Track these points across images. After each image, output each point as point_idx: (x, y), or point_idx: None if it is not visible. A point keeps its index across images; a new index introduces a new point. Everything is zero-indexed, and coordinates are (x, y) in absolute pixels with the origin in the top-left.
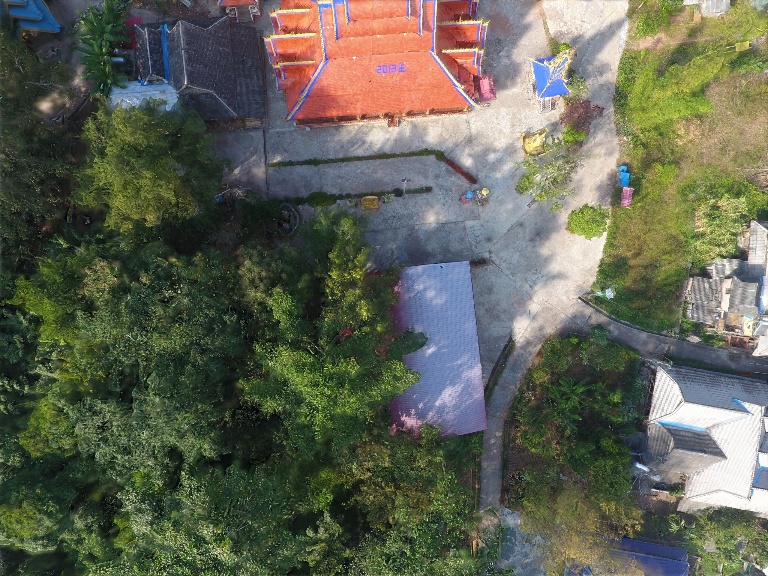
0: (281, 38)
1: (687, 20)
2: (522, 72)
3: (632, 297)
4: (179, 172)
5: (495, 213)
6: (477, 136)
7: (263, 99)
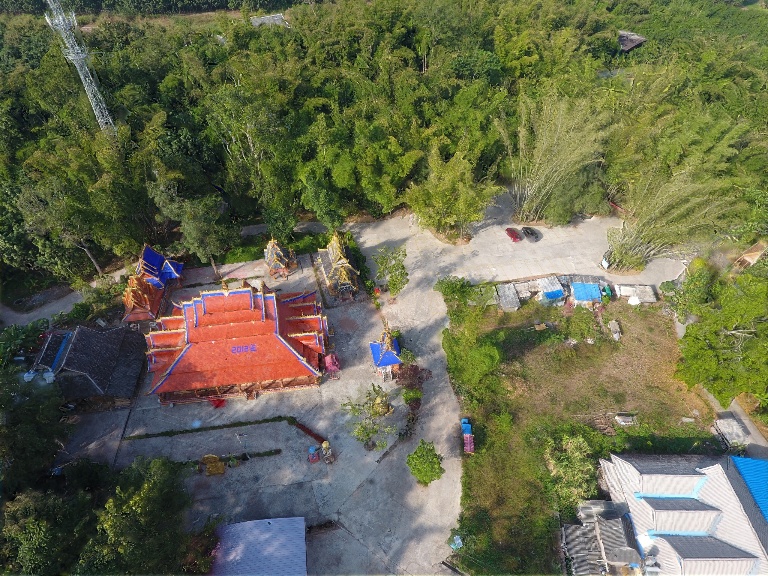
0: (158, 334)
1: (494, 315)
2: (367, 354)
3: (502, 556)
4: (0, 420)
5: (344, 471)
6: (328, 403)
7: (137, 383)
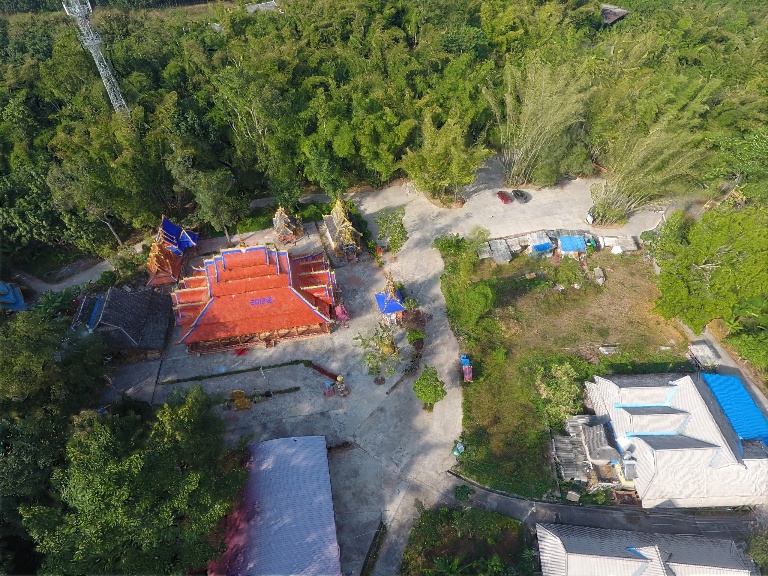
0: (183, 292)
1: (488, 267)
2: (373, 305)
3: (499, 463)
4: (56, 357)
5: (357, 402)
6: (339, 347)
7: None
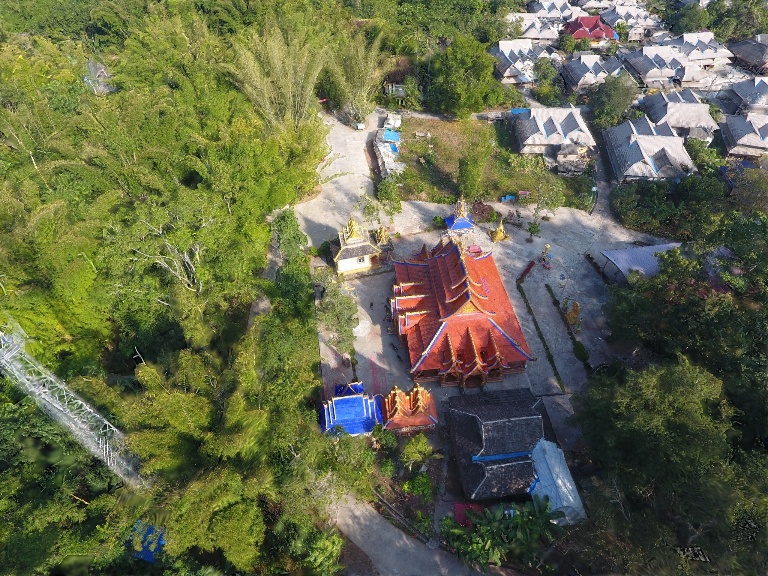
0: None
1: None
2: None
3: None
4: None
5: (551, 252)
6: (500, 263)
7: None
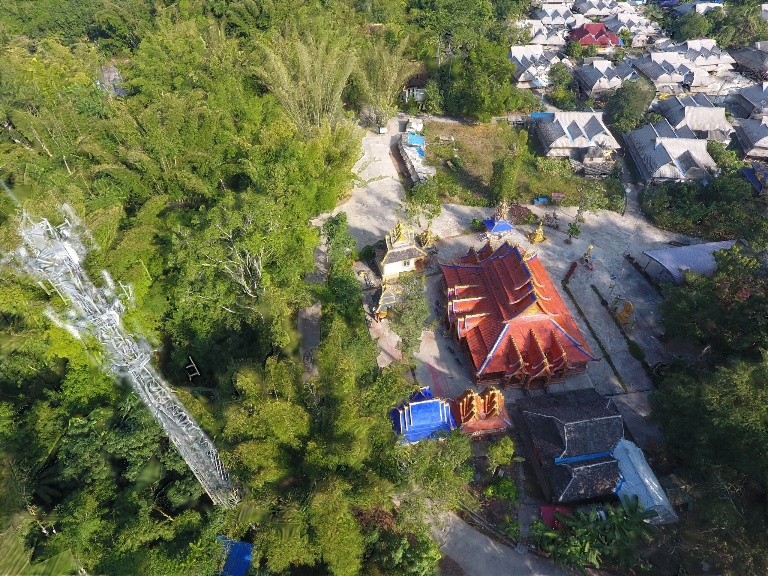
0: None
1: None
2: None
3: (610, 195)
4: None
5: (591, 253)
6: (542, 264)
7: None
